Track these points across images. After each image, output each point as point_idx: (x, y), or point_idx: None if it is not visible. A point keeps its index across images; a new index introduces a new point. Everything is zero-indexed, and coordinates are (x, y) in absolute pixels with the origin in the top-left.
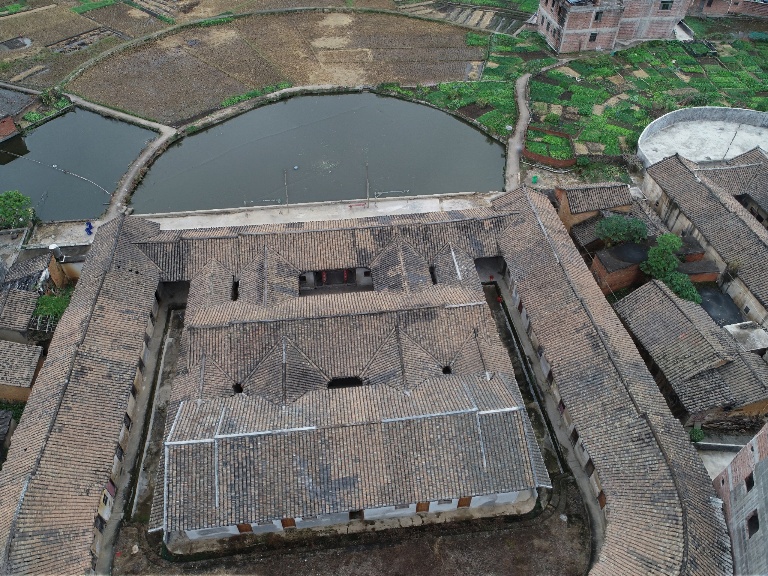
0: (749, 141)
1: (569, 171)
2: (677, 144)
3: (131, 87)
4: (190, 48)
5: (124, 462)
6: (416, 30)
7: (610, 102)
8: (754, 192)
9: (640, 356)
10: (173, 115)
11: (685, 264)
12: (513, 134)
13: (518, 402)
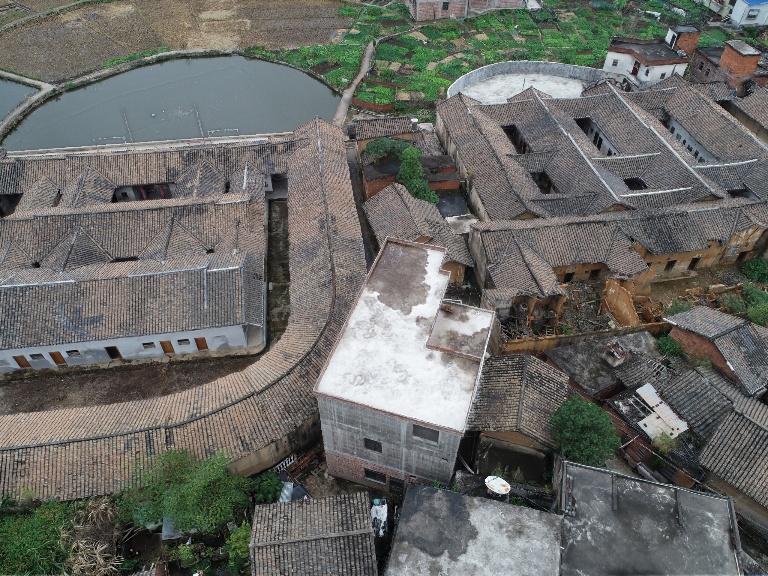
0: (553, 89)
1: (389, 115)
2: (489, 92)
3: (26, 53)
4: (88, 21)
5: None
6: (297, 3)
7: (445, 60)
8: (519, 123)
9: (361, 236)
10: (57, 75)
11: (432, 174)
12: (349, 86)
13: (243, 264)
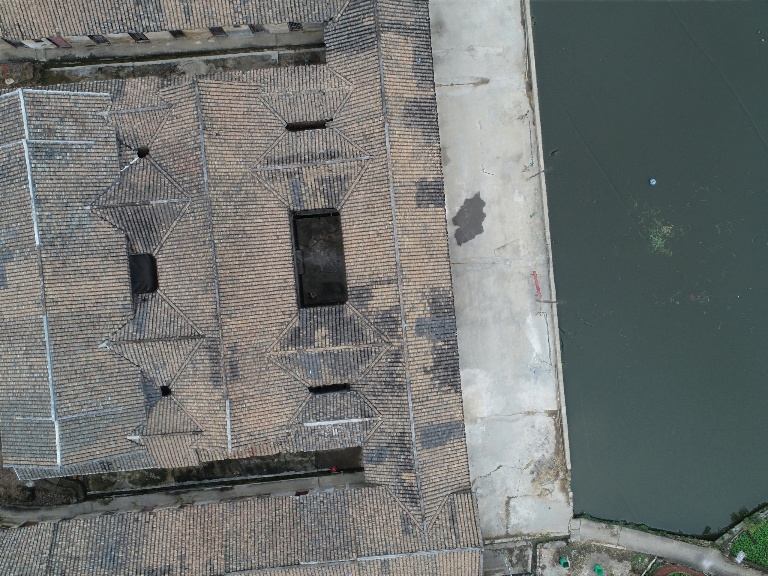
0: None
1: None
2: None
3: None
4: None
5: (102, 46)
6: None
7: None
8: None
9: None
10: None
11: None
12: (733, 560)
13: None
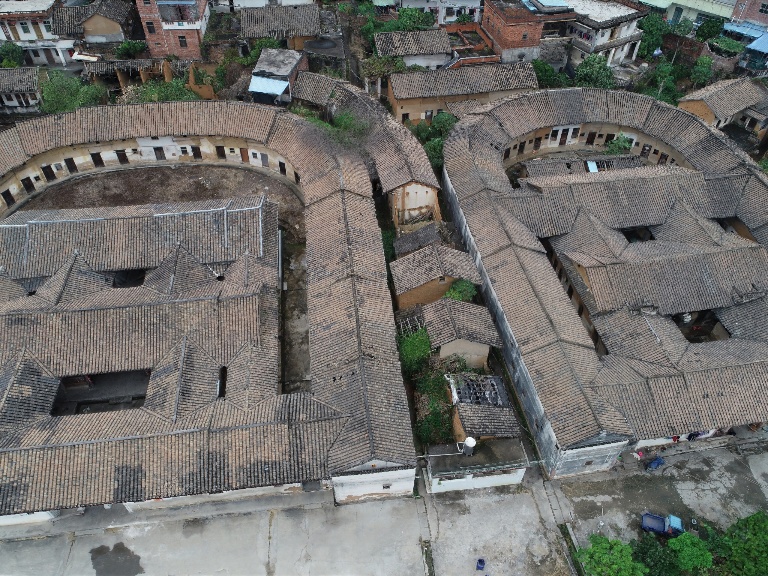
0: None
1: None
2: None
3: None
4: None
5: None
6: None
7: None
8: None
9: None
10: None
11: None
12: None
13: None
